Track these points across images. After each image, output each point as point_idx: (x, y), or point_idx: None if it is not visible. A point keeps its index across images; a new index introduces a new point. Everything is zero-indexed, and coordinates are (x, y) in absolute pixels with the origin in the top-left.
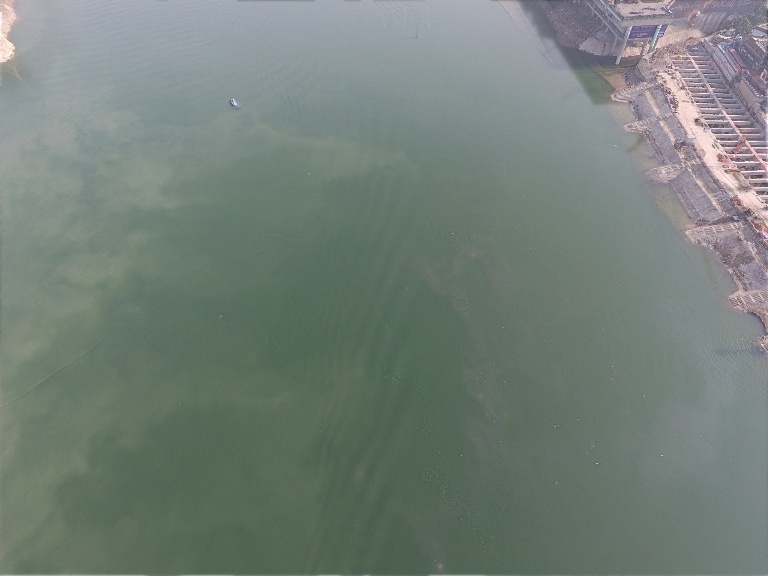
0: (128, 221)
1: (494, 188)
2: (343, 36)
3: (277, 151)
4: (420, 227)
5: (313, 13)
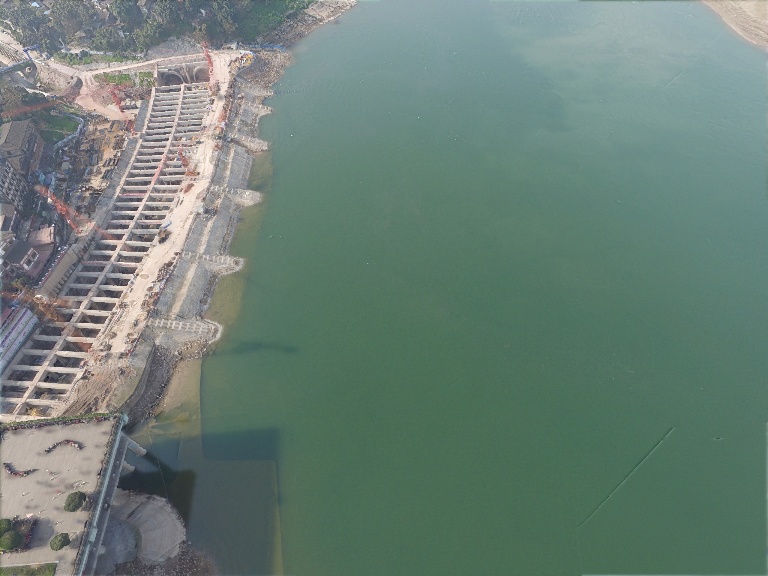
0: (754, 156)
1: None
2: None
3: (682, 229)
4: (483, 152)
5: None
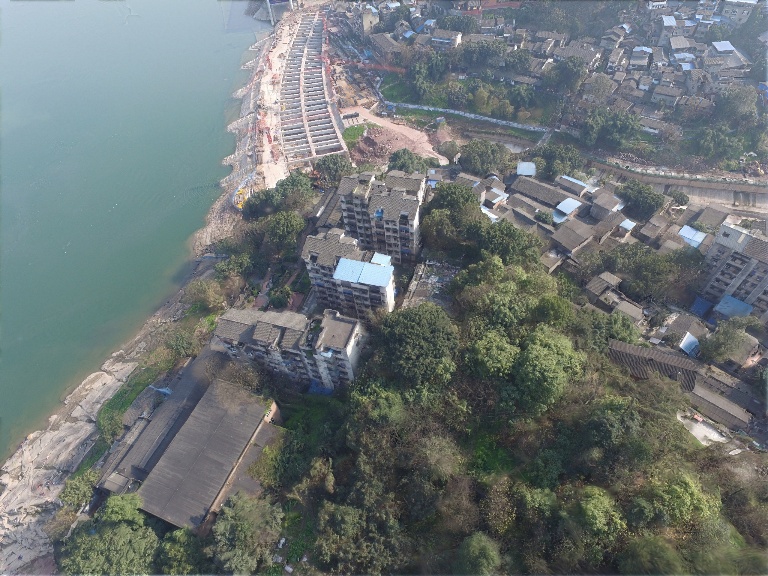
0: None
1: None
2: (76, 25)
3: None
4: None
5: (72, 11)
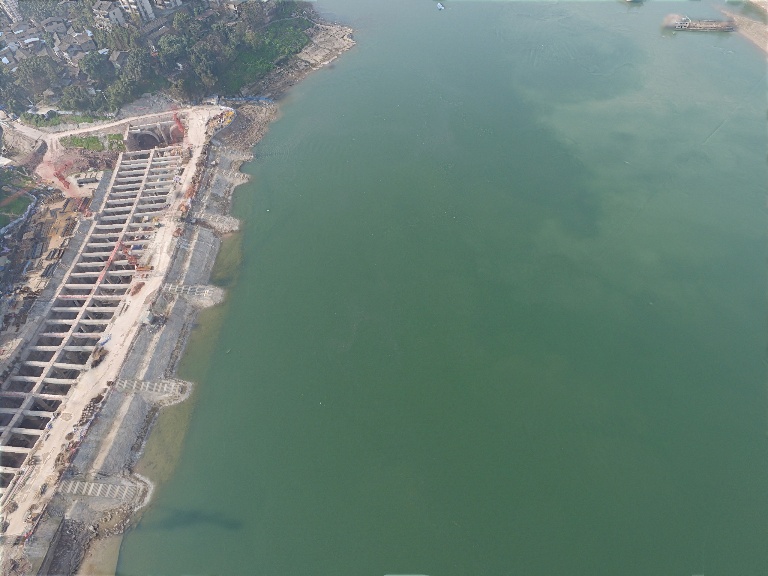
0: None
1: None
2: None
3: (732, 345)
4: (487, 233)
5: None
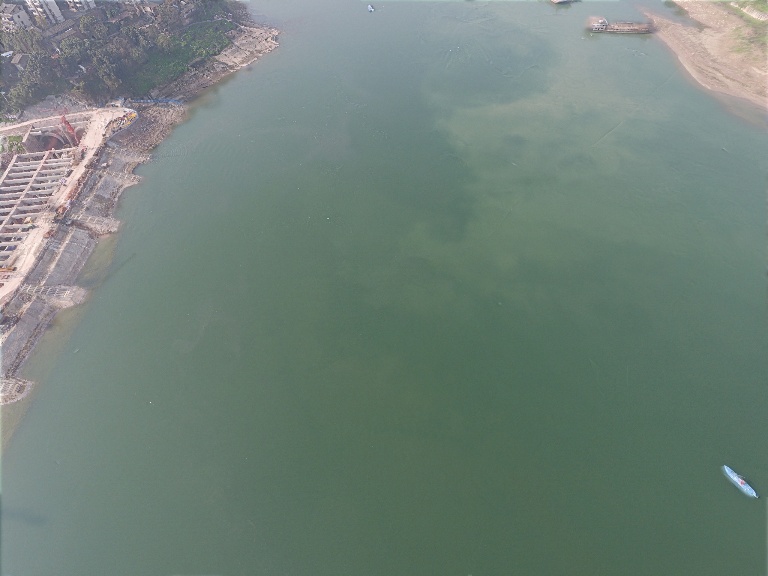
0: (680, 239)
1: (270, 275)
2: None
3: (567, 345)
4: (359, 234)
5: None
